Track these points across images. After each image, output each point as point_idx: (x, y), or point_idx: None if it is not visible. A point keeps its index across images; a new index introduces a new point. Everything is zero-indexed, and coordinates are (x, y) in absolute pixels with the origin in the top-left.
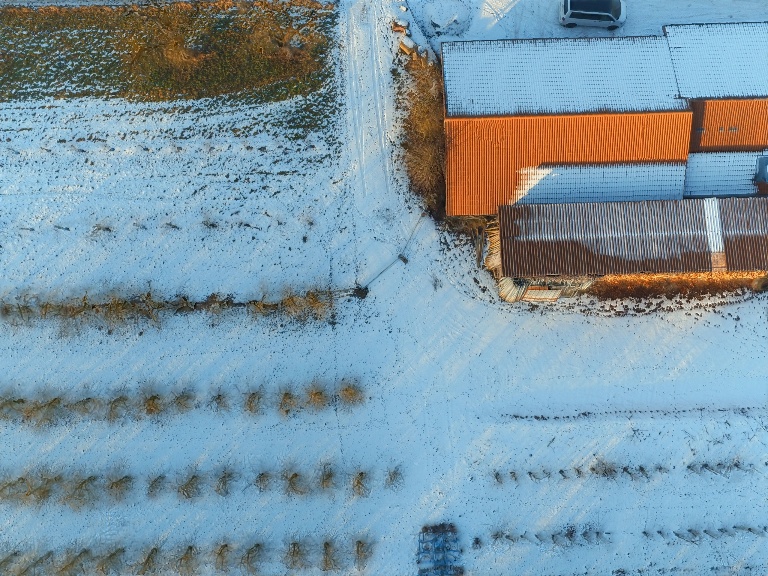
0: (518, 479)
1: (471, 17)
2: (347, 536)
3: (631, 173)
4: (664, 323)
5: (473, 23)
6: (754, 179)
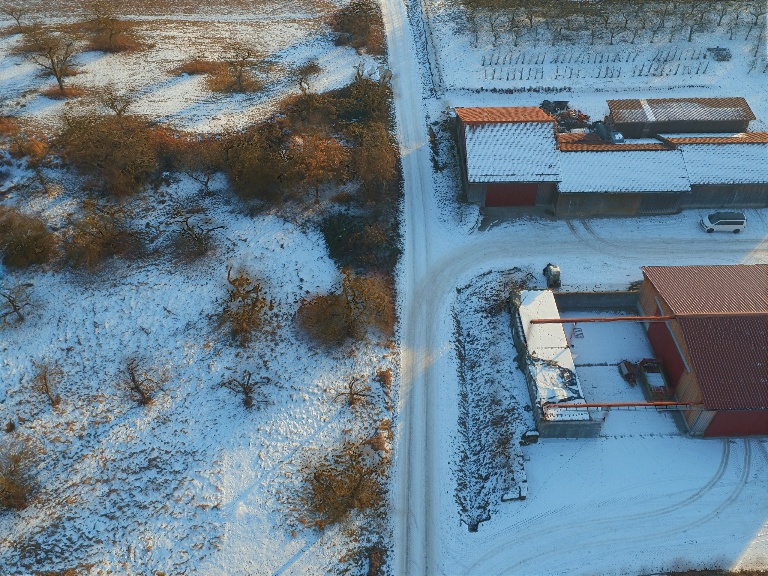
0: (693, 72)
1: None
2: (760, 58)
3: None
4: None
5: None
6: None
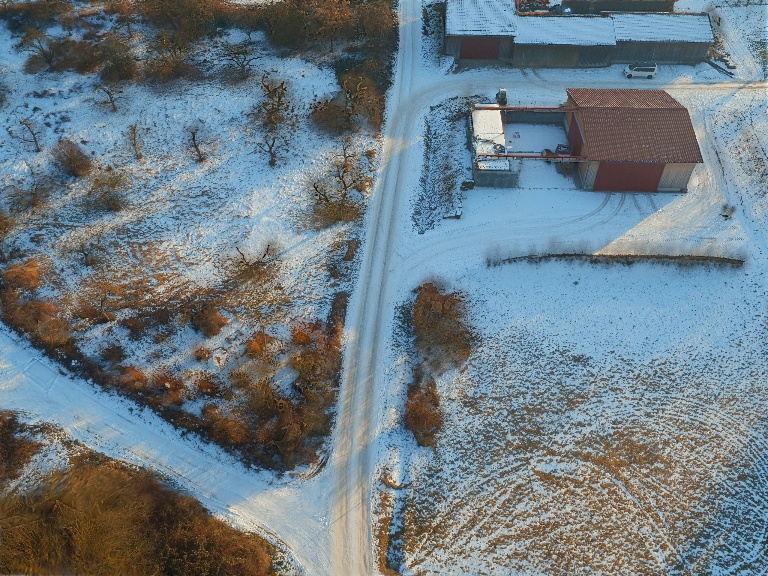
0: None
1: None
2: None
3: None
4: None
5: None
6: None
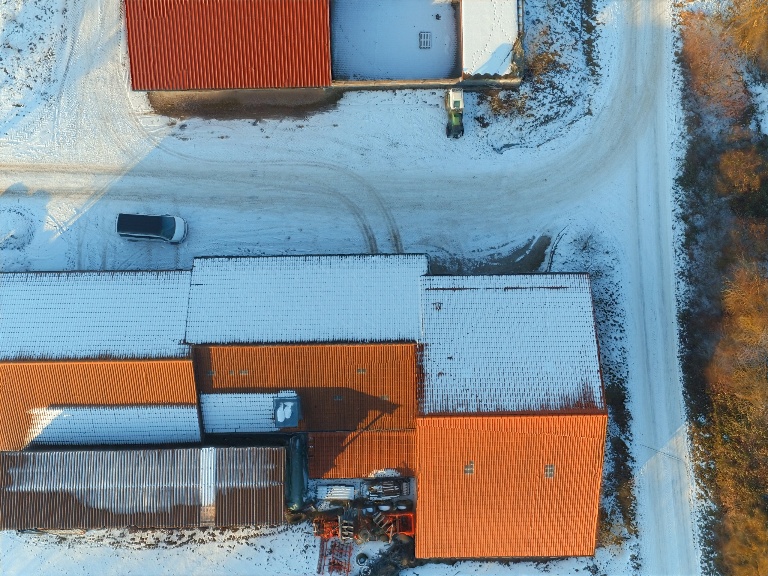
0: None
1: (32, 230)
2: None
3: (143, 415)
4: (195, 556)
5: (35, 236)
6: (274, 418)
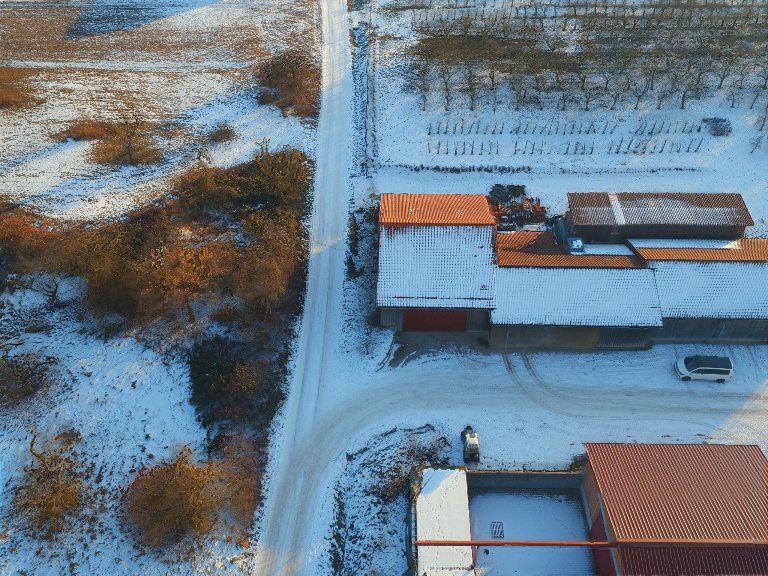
0: (683, 150)
1: None
2: (767, 133)
3: None
4: None
5: None
6: None
